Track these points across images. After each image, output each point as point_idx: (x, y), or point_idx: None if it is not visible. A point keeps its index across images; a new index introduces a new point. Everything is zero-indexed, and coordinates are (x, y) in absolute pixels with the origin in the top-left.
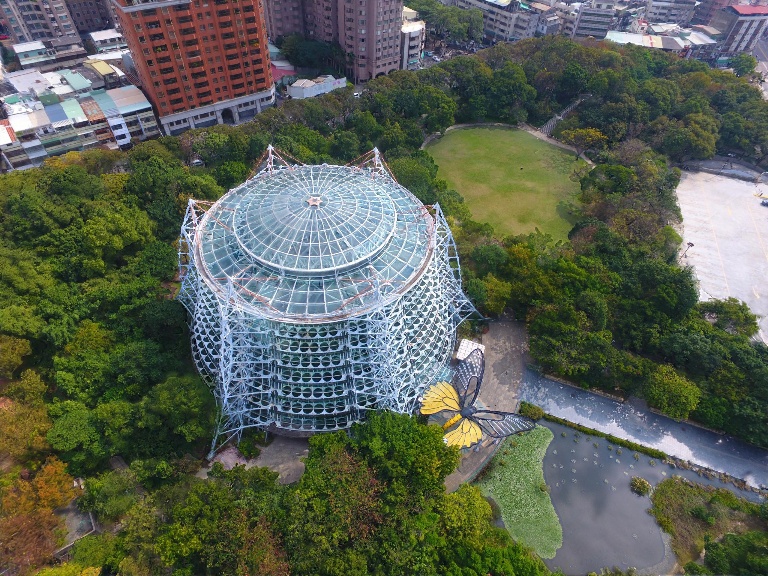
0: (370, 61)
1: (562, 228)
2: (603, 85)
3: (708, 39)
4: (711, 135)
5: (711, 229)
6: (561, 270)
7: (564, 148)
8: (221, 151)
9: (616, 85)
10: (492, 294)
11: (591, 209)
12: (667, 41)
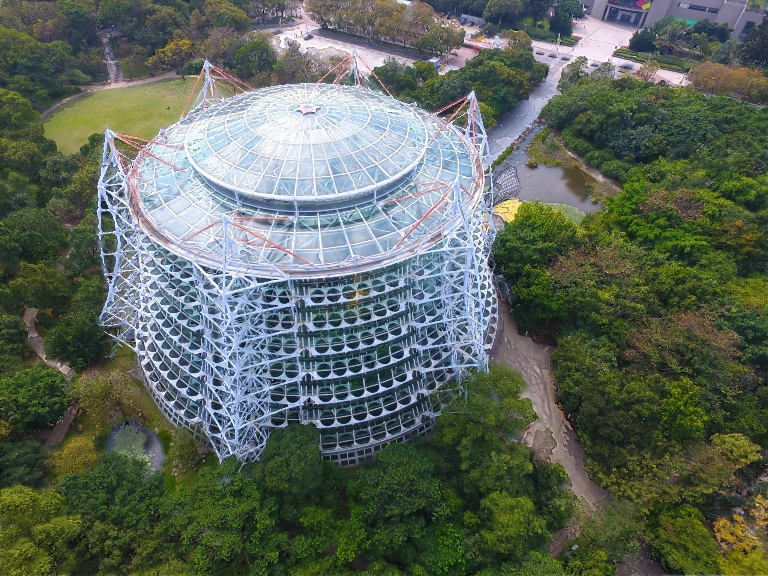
0: None
1: None
2: (124, 5)
3: None
4: (236, 8)
5: None
6: None
7: (158, 80)
8: None
9: (129, 2)
10: None
11: None
12: None
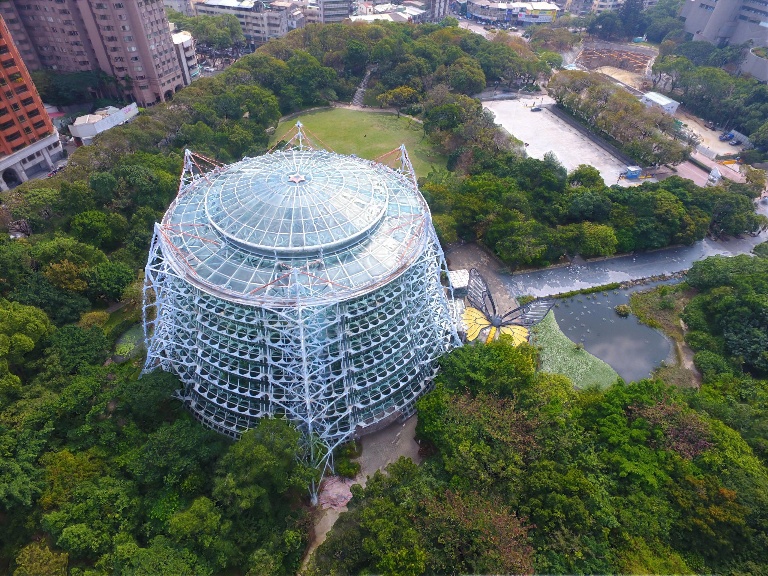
0: (152, 80)
1: None
2: (388, 51)
3: (419, 10)
4: (479, 71)
5: (519, 136)
6: (474, 189)
7: (382, 112)
8: (57, 207)
9: (395, 50)
10: (443, 227)
11: (447, 144)
12: (394, 16)
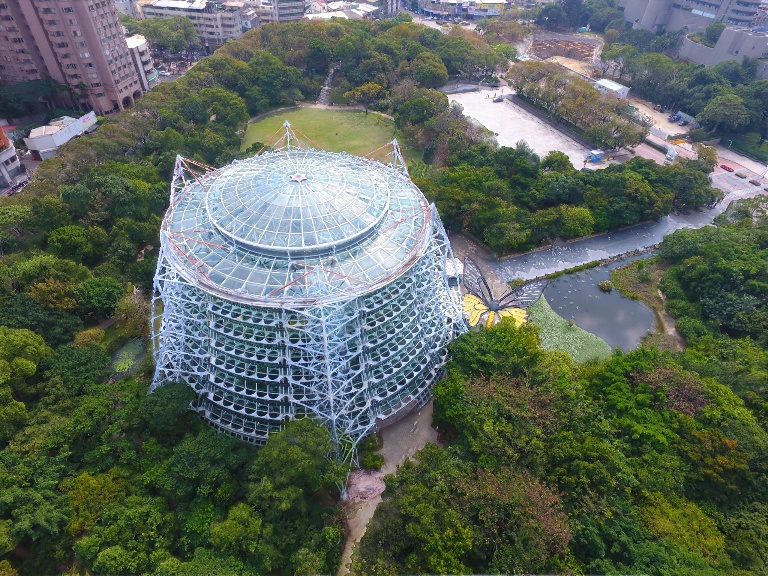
0: (108, 87)
1: (408, 163)
2: (350, 48)
3: (372, 7)
4: (441, 64)
5: None
6: (455, 180)
7: (349, 109)
8: (30, 224)
9: (357, 47)
10: None
11: (420, 138)
12: (349, 13)
